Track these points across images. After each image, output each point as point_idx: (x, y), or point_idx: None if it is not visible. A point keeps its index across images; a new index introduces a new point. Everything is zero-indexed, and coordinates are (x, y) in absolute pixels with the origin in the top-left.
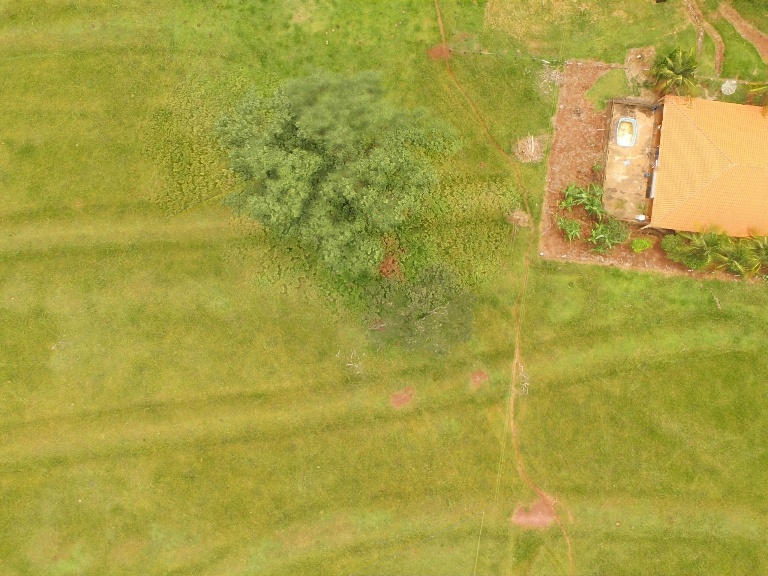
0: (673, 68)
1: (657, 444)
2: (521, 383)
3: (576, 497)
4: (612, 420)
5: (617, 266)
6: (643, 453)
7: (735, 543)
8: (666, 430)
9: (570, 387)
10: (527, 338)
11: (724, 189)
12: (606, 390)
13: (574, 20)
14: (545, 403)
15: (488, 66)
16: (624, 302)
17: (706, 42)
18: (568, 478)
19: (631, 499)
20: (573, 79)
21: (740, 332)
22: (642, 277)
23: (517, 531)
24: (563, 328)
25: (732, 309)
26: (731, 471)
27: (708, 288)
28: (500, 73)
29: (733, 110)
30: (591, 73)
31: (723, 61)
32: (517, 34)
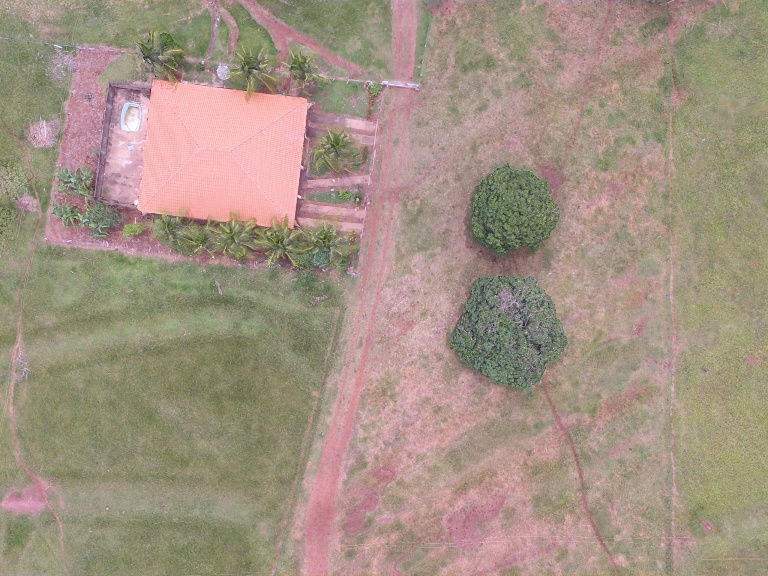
0: (142, 52)
1: (155, 429)
2: (20, 368)
3: (70, 482)
4: (110, 405)
5: (121, 251)
6: (140, 438)
7: (226, 528)
8: (163, 415)
9: (71, 372)
10: (29, 323)
11: (197, 173)
12: (106, 375)
13: (90, 5)
14: (45, 388)
15: (1, 51)
16: (126, 287)
17: (221, 27)
18: (64, 463)
19: (125, 484)
20: (86, 64)
21: (239, 317)
22: (144, 262)
23: (9, 516)
24: (64, 313)
25: (233, 294)
26: (226, 456)
27: (211, 273)
28: (12, 58)
29: (217, 95)
30: (103, 58)
31: (236, 46)
32: (31, 19)
